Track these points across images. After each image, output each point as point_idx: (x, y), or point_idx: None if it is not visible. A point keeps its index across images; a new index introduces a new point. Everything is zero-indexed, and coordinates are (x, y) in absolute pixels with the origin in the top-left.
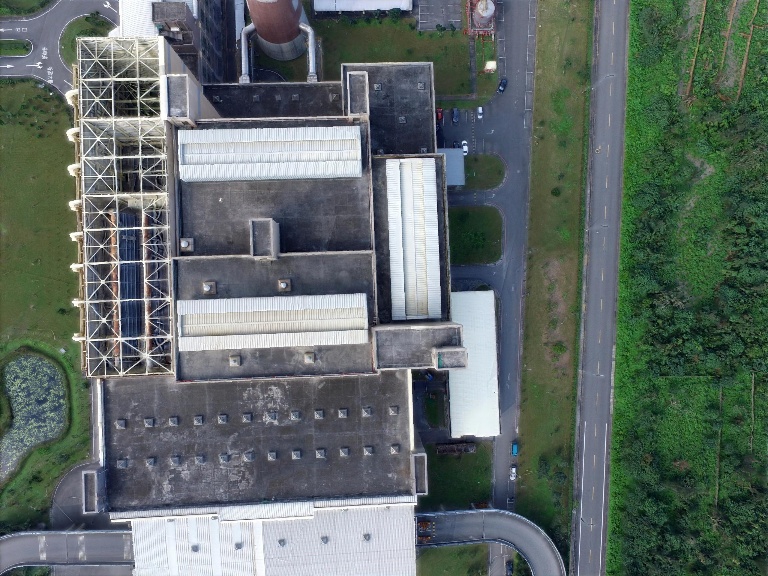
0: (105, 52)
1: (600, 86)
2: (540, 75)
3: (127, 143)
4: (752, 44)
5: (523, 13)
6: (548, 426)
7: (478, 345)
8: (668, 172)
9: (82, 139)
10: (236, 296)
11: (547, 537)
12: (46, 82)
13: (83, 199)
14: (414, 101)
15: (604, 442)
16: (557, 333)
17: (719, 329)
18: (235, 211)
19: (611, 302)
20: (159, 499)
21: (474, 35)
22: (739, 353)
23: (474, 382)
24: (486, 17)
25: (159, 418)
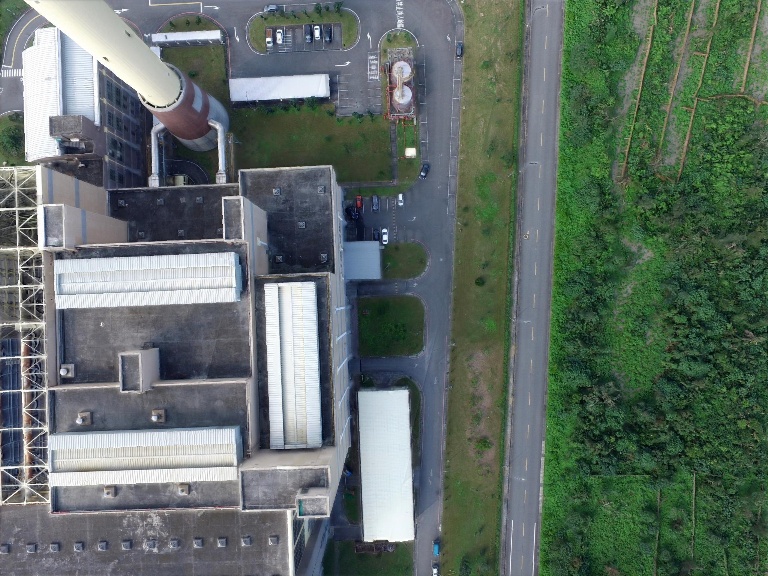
0: None
1: (528, 168)
2: (464, 159)
3: (26, 257)
4: (696, 118)
5: (446, 94)
6: (472, 525)
7: (391, 447)
8: (601, 259)
9: None
10: (112, 426)
11: None
12: None
13: None
14: (314, 205)
15: (533, 542)
16: (482, 428)
17: (655, 427)
18: (116, 336)
19: (540, 395)
20: None
21: (395, 119)
22: (678, 452)
23: (387, 485)
24: (403, 104)
25: (41, 544)
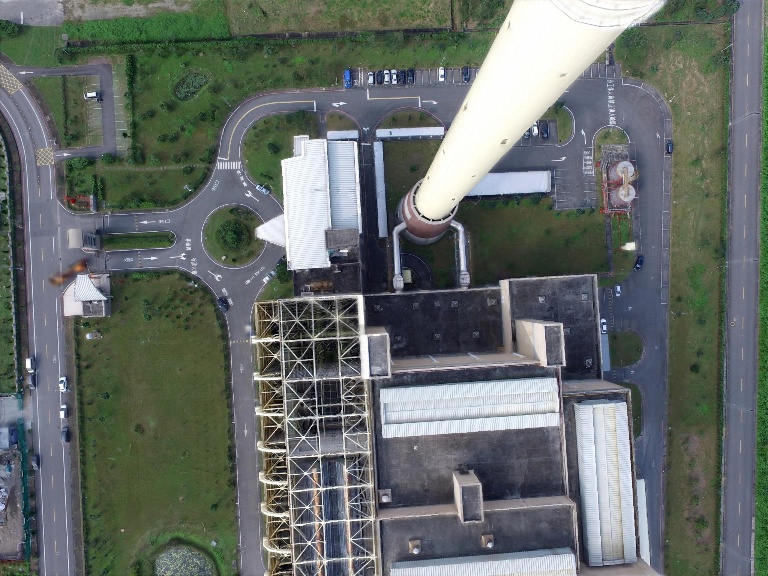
0: (305, 312)
1: (734, 259)
2: (675, 251)
3: None
4: None
5: (657, 189)
6: None
7: None
8: None
9: (285, 401)
10: (439, 552)
11: None
12: (190, 273)
13: (288, 461)
14: (577, 312)
15: None
16: (698, 508)
17: None
18: (430, 458)
19: (749, 474)
20: None
21: (610, 213)
22: None
23: None
24: (627, 202)
25: None
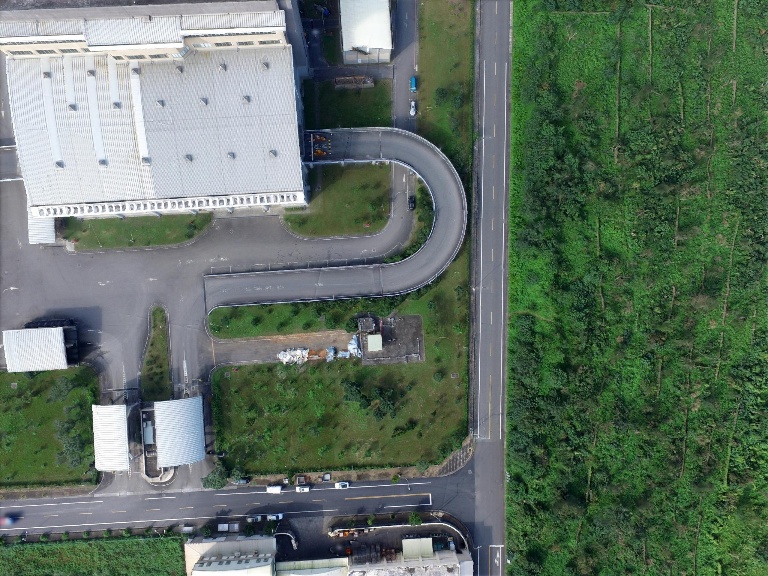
0: None
1: None
2: None
3: None
4: None
5: None
6: (447, 62)
7: None
8: None
9: None
10: None
11: (445, 158)
12: None
13: None
14: None
15: (504, 81)
16: None
17: None
18: None
19: None
20: (20, 4)
21: None
22: None
23: None
24: None
25: None
